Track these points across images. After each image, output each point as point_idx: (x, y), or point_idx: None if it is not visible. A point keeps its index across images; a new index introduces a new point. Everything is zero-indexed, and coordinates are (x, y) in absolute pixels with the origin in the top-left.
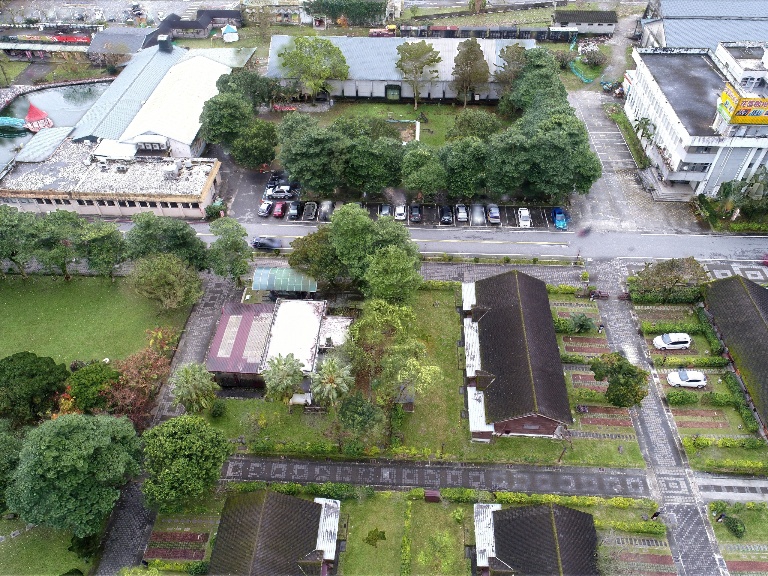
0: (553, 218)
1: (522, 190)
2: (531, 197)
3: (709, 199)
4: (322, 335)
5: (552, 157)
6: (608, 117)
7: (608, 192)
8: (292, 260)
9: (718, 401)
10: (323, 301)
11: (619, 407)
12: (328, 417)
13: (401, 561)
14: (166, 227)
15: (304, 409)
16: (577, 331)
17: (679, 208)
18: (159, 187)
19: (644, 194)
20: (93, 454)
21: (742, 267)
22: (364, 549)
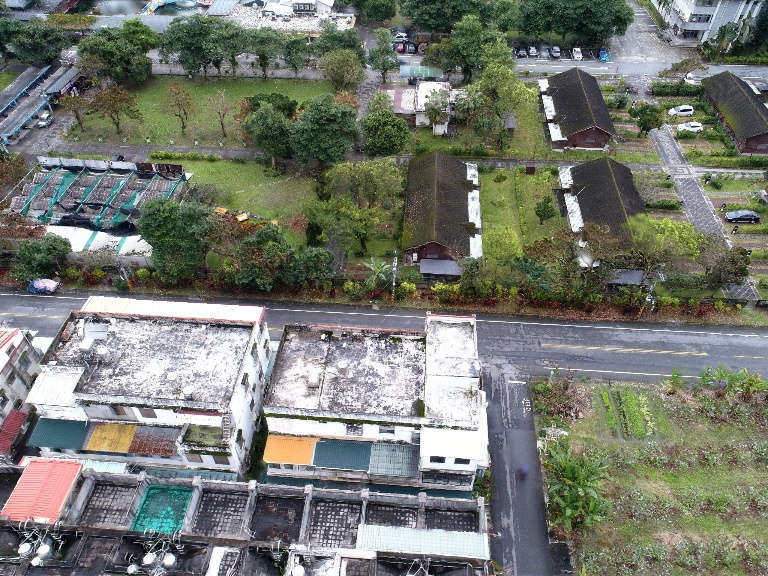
0: (598, 54)
1: (576, 33)
2: (581, 44)
3: (710, 38)
4: (451, 97)
5: (600, 4)
6: (637, 2)
7: (637, 42)
8: (424, 60)
9: (710, 135)
10: (448, 82)
11: (646, 131)
12: (458, 140)
13: (516, 190)
14: (344, 33)
15: (442, 137)
16: (617, 106)
17: (689, 51)
18: (316, 29)
19: (664, 43)
20: (341, 117)
21: None
22: (492, 190)
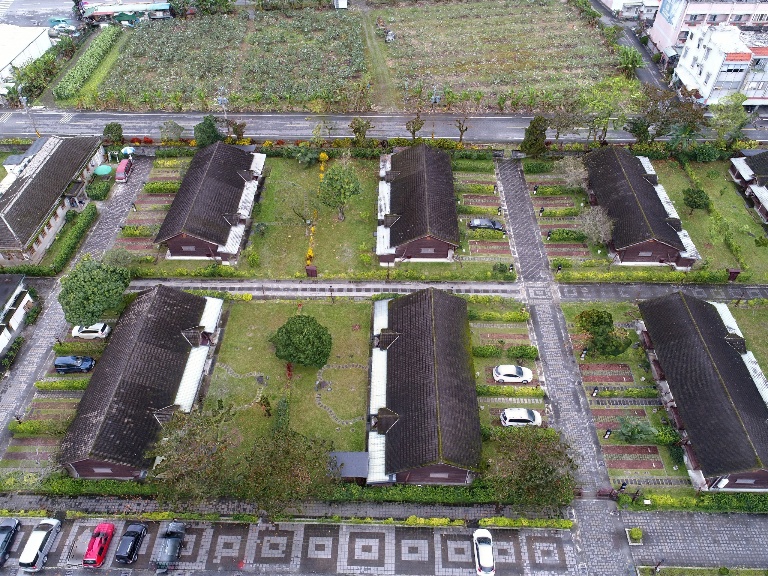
0: None
1: None
2: None
3: None
4: None
5: None
6: None
7: None
8: None
9: None
10: None
11: None
12: None
13: None
14: None
15: None
16: None
17: None
18: None
19: None
20: None
21: (378, 568)
22: (762, 252)
